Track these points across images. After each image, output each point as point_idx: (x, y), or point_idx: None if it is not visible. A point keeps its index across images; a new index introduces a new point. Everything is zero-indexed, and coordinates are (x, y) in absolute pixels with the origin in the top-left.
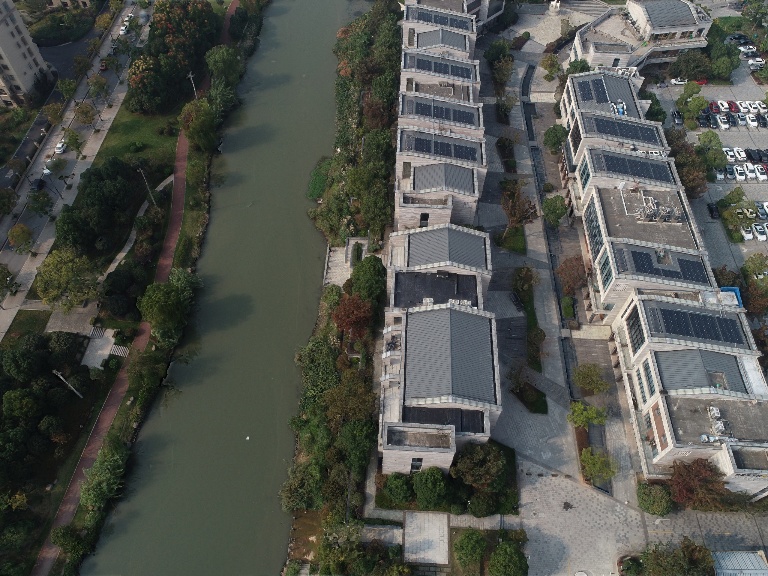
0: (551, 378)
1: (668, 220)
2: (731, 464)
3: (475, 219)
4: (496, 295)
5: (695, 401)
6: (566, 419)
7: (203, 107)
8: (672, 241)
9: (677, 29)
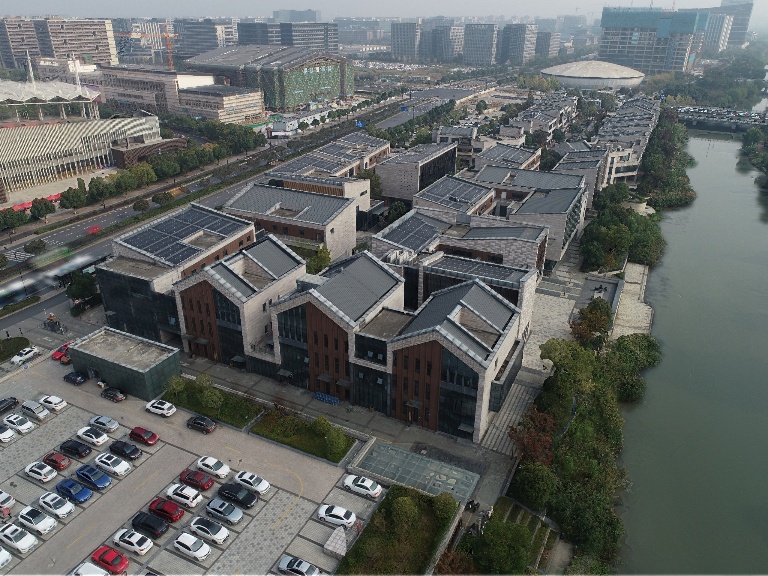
0: None
1: None
2: None
3: None
4: None
5: None
6: None
7: None
8: None
9: None
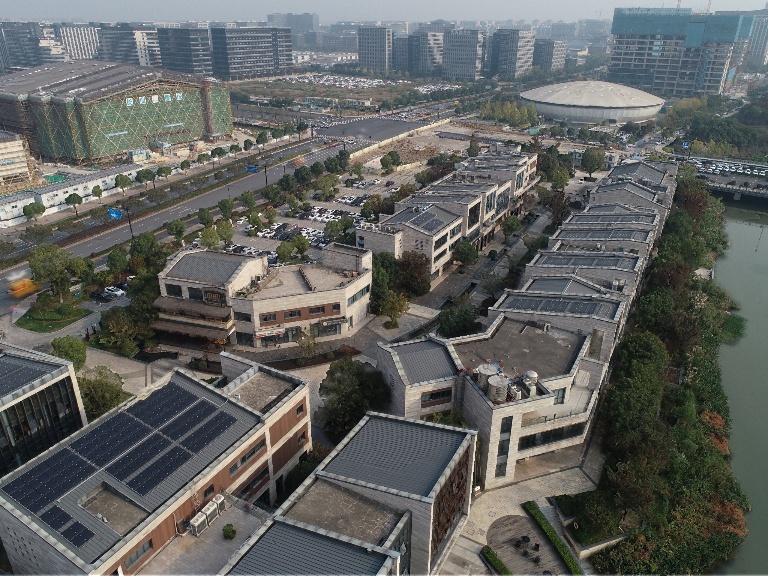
0: None
1: None
2: None
3: None
4: None
5: None
6: None
7: None
8: None
9: None
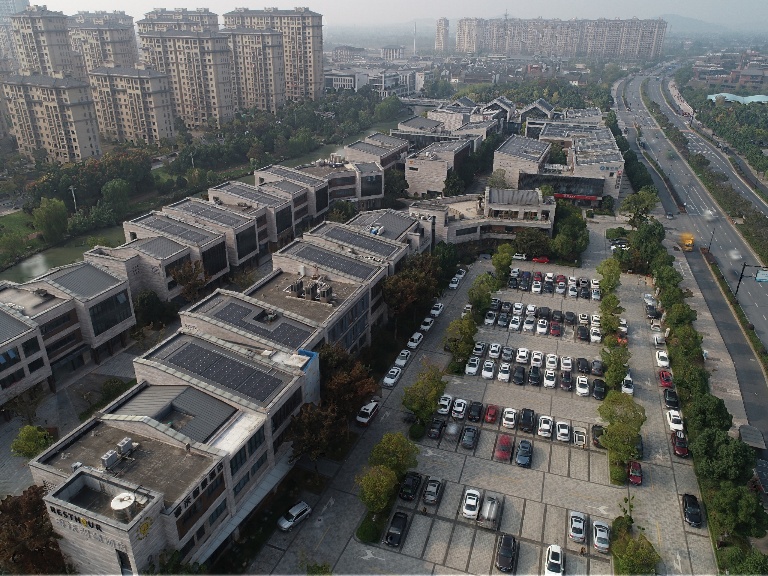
0: None
1: (318, 298)
2: None
3: None
4: (132, 358)
5: (127, 434)
6: None
7: (54, 203)
8: (304, 314)
9: (517, 207)
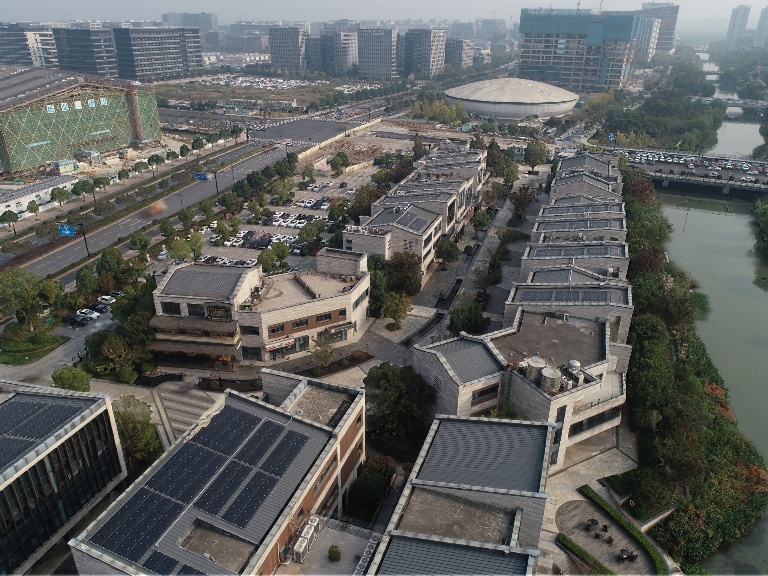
0: None
1: None
2: None
3: None
4: None
5: None
6: None
7: None
8: None
9: None
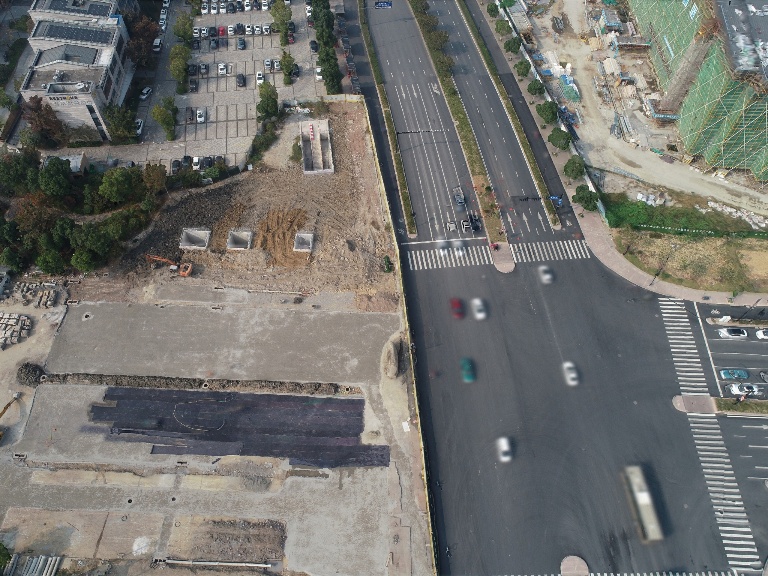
0: (8, 94)
1: None
2: (45, 92)
3: (2, 15)
4: None
5: (53, 71)
6: (7, 113)
7: None
8: None
9: None
